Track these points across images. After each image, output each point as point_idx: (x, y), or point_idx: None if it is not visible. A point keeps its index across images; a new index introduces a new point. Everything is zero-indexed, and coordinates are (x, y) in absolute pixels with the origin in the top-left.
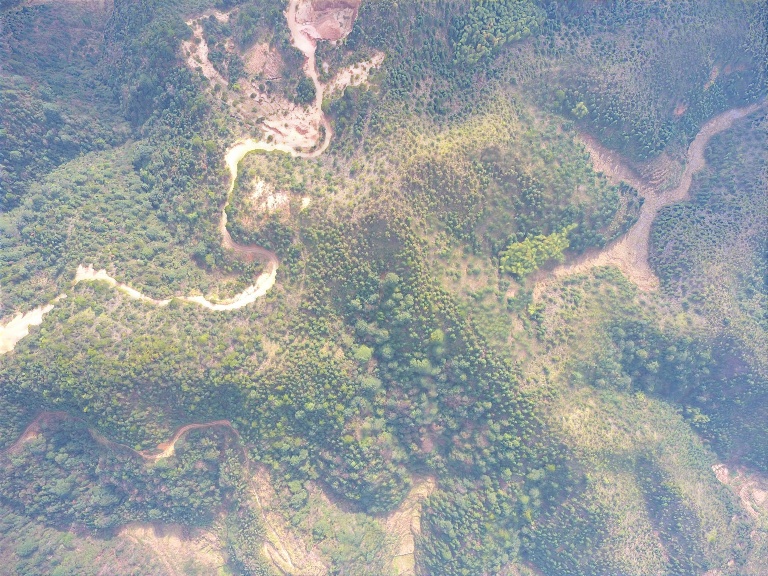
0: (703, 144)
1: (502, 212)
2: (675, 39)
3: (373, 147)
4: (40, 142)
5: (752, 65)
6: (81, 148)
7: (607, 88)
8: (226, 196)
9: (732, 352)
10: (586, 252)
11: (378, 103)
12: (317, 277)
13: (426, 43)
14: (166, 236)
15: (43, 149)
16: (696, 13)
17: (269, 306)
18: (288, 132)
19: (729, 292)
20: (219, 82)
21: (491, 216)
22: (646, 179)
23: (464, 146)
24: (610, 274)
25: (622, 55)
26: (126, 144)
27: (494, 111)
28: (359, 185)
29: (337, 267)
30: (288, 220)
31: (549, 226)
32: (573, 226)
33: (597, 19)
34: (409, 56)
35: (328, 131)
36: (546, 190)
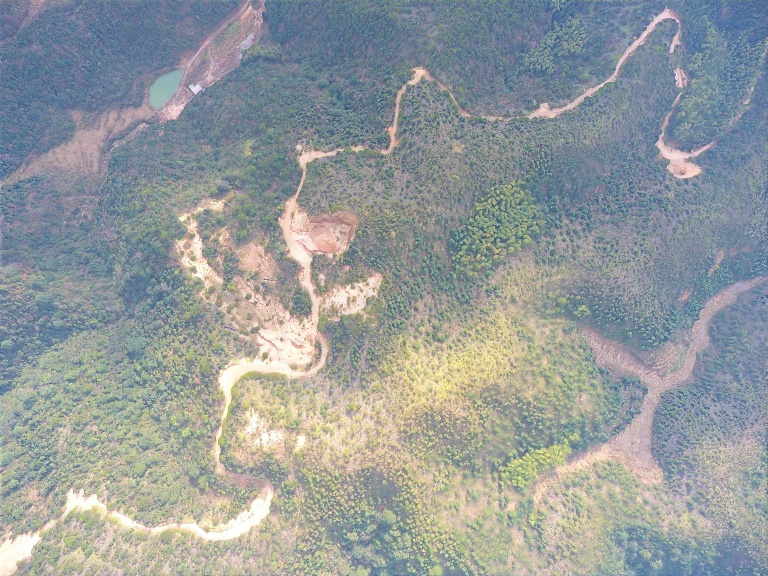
0: (708, 320)
1: (502, 435)
2: (679, 235)
3: (370, 385)
4: (32, 328)
5: (758, 248)
6: (74, 329)
7: (610, 292)
8: (220, 422)
9: (738, 550)
10: (588, 446)
11: (375, 335)
12: (312, 519)
13: (424, 260)
14: (159, 443)
15: (35, 334)
16: (701, 202)
17: (263, 541)
18: (283, 346)
19: (735, 491)
20: (213, 282)
21: (491, 442)
22: (649, 365)
23: (463, 387)
24: (613, 473)
25: (625, 255)
26: (120, 322)
27: (494, 338)
28: (355, 428)
29: (333, 511)
30: (283, 456)
31: (550, 437)
32: (575, 437)
33: (599, 208)
34: (407, 276)
35: (324, 347)
36: (547, 409)
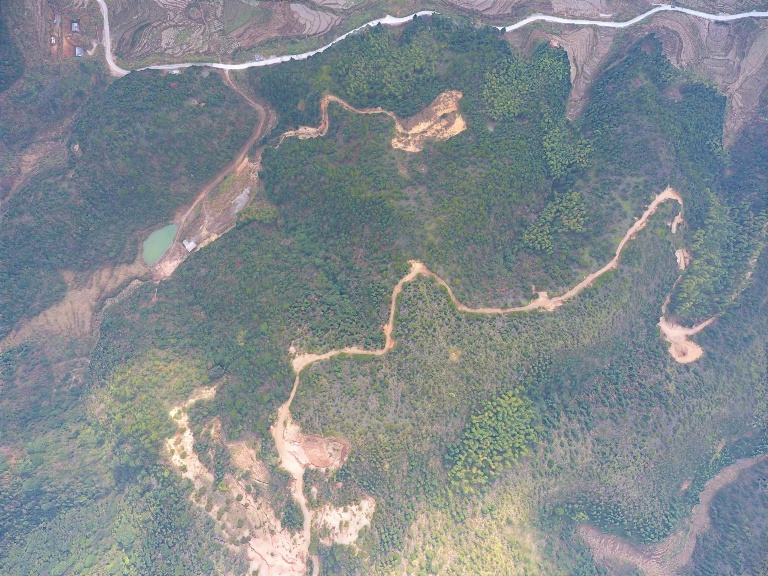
0: (708, 500)
1: None
2: (680, 435)
3: None
4: (19, 512)
5: (760, 436)
6: (62, 507)
7: (608, 499)
8: None
9: None
10: None
11: (367, 570)
12: None
13: None
14: None
15: (23, 516)
16: (702, 395)
17: None
18: (274, 561)
19: None
20: (204, 482)
21: None
22: (648, 555)
23: None
24: None
25: (624, 460)
26: (109, 499)
27: (489, 569)
28: None
29: None
30: None
31: None
32: None
33: (599, 400)
34: (401, 498)
35: (316, 565)
36: None
